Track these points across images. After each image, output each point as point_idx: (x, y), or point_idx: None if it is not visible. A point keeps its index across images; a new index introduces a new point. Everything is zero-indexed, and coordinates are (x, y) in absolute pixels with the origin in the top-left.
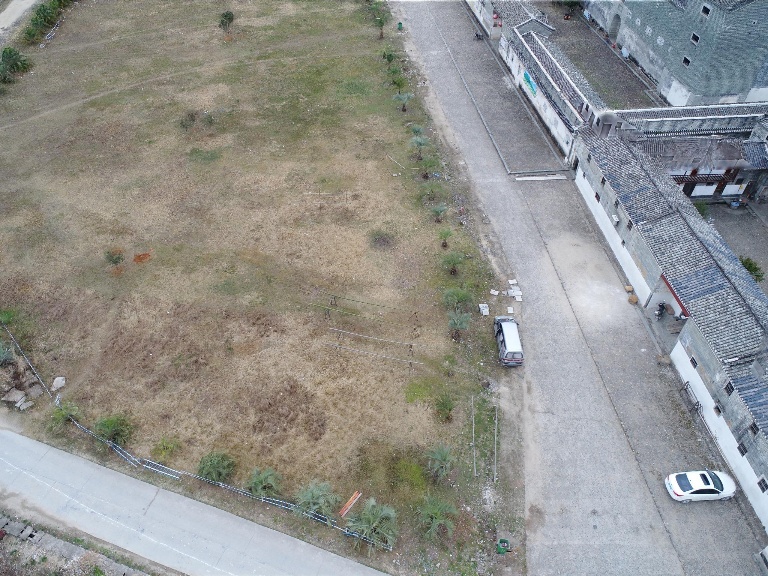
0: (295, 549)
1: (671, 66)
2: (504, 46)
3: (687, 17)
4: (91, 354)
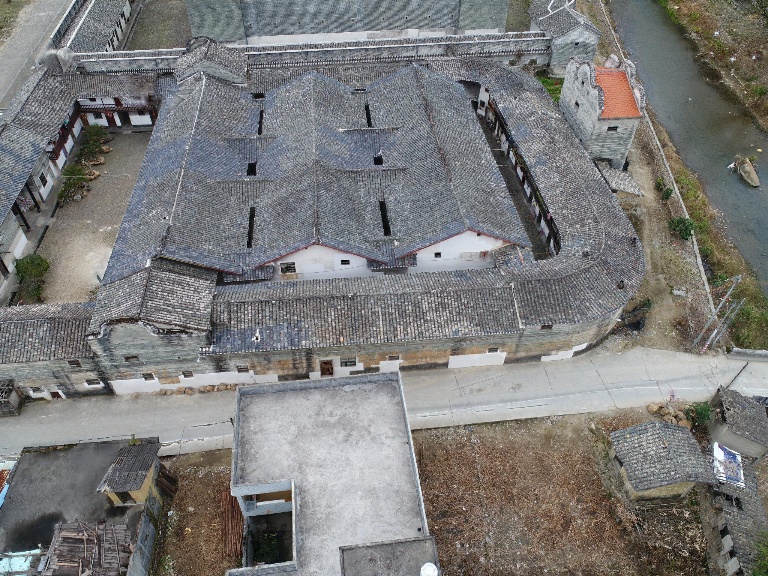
0: None
1: None
2: None
3: None
4: None
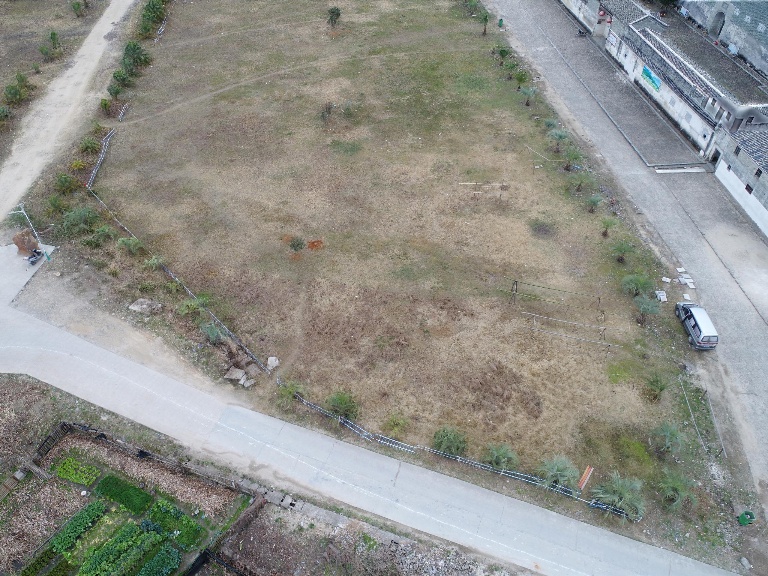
0: (548, 519)
1: None
2: (614, 42)
3: None
4: (295, 335)
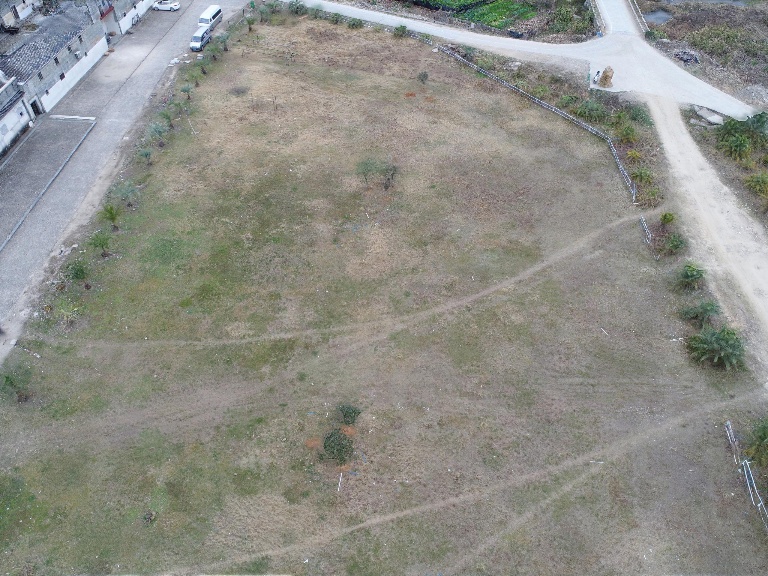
0: None
1: None
2: None
3: None
4: None
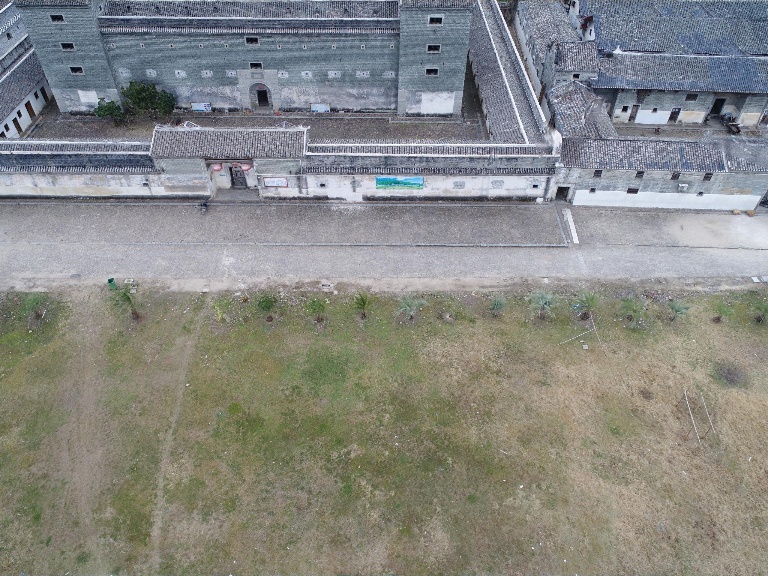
0: None
1: (410, 85)
2: (283, 183)
3: (409, 36)
4: None
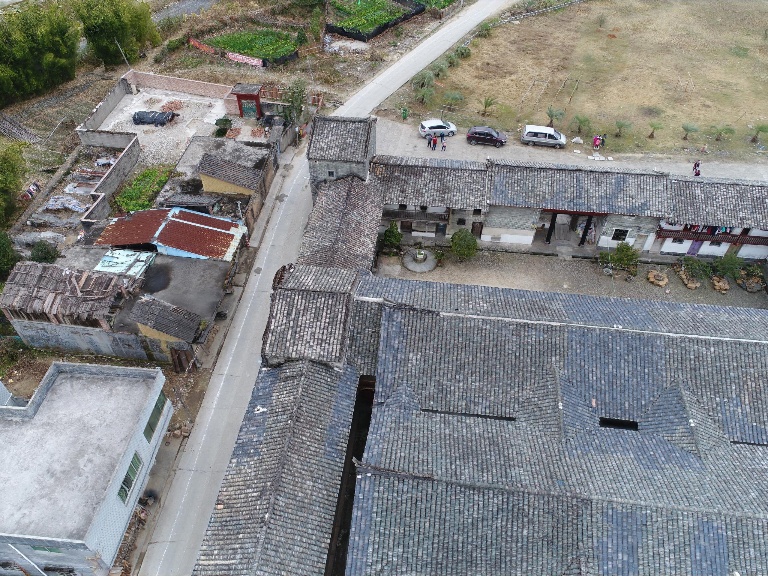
0: None
1: None
2: None
3: None
4: None
